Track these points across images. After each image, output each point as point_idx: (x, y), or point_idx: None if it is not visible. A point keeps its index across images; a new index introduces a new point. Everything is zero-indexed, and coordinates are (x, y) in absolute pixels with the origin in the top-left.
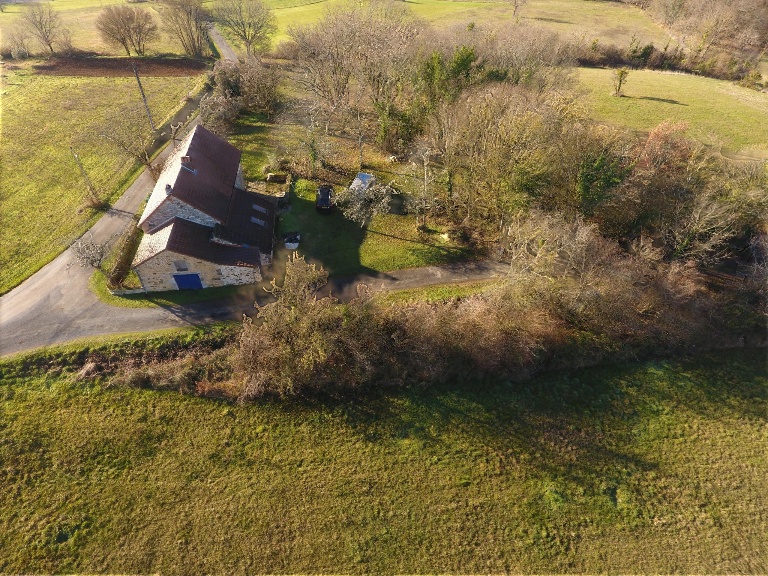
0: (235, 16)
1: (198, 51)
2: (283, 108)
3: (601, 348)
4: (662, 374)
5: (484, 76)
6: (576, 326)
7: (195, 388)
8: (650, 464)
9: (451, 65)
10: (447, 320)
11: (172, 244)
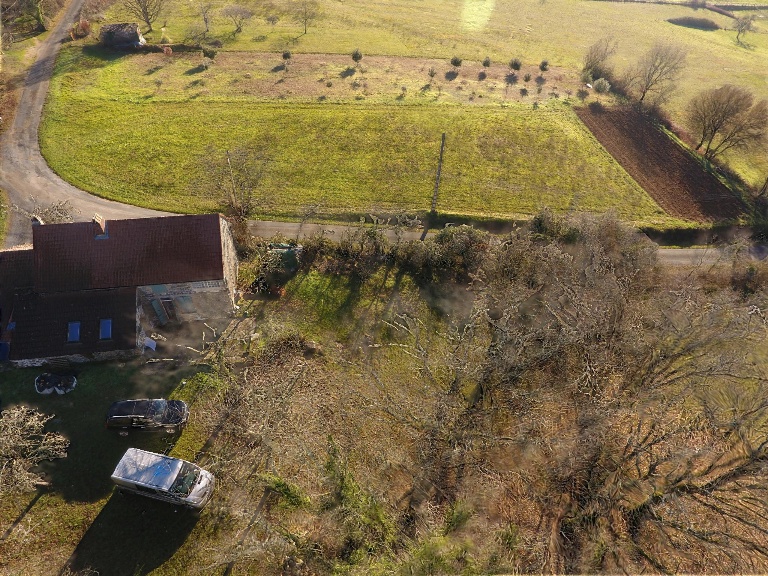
0: None
1: None
2: None
3: None
4: None
5: None
6: None
7: None
8: None
9: None
10: None
11: None
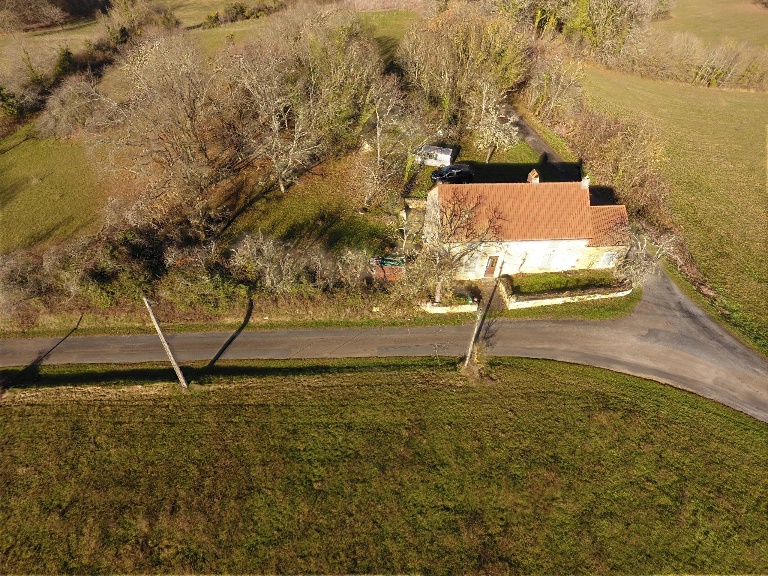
0: None
1: None
2: None
3: None
4: None
5: None
6: None
7: None
8: None
9: None
10: None
11: None
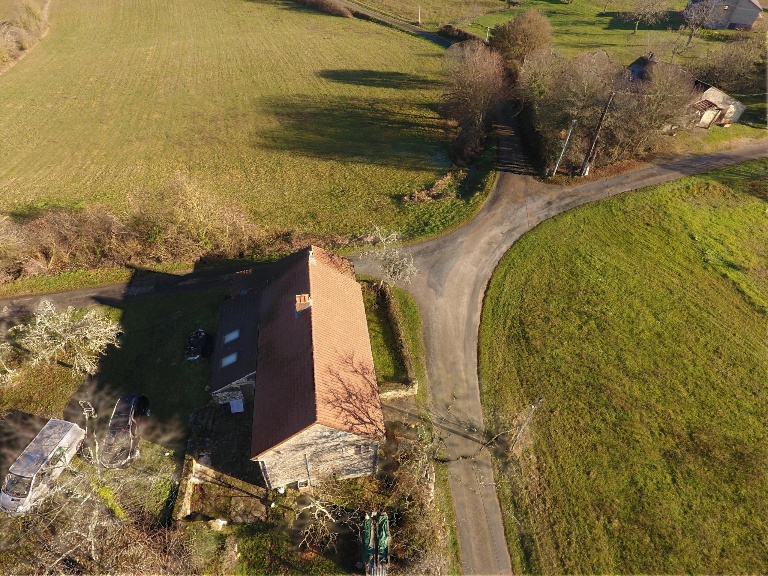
0: None
1: None
2: None
3: None
4: None
5: None
6: None
7: None
8: (5, 212)
9: None
10: None
11: None
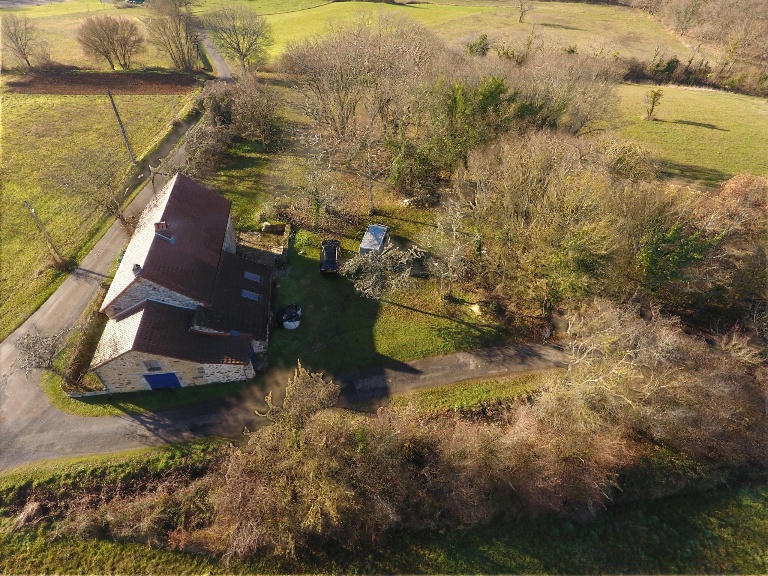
0: (228, 28)
1: (188, 64)
2: (280, 134)
3: (683, 474)
4: (761, 508)
5: (516, 111)
6: (646, 437)
7: (167, 541)
8: None
9: (476, 96)
10: (494, 451)
11: (141, 341)
